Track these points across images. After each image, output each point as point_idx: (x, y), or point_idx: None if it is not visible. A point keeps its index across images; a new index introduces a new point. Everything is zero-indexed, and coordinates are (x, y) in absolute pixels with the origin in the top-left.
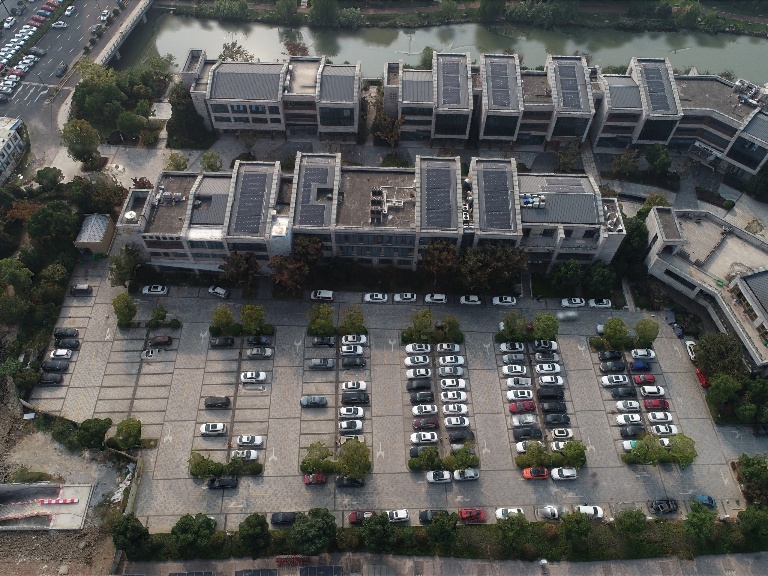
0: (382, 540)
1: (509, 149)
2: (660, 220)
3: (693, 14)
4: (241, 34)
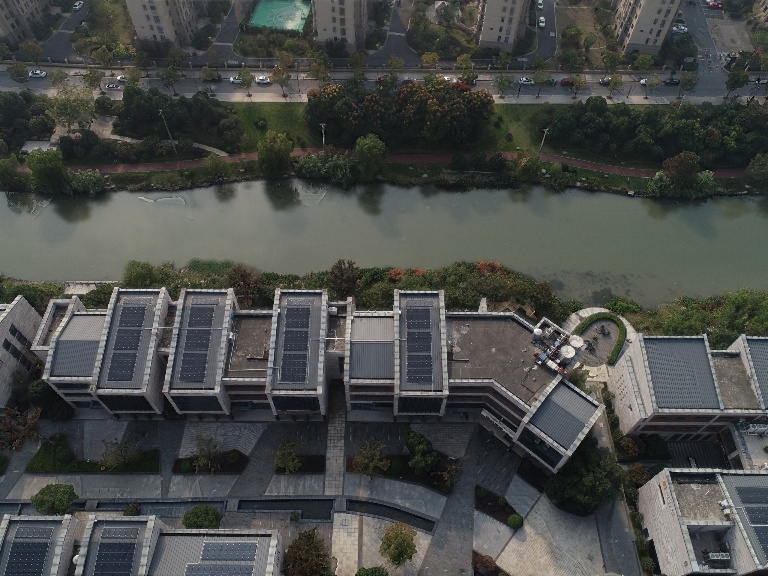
0: None
1: (228, 418)
2: None
3: (530, 170)
4: None
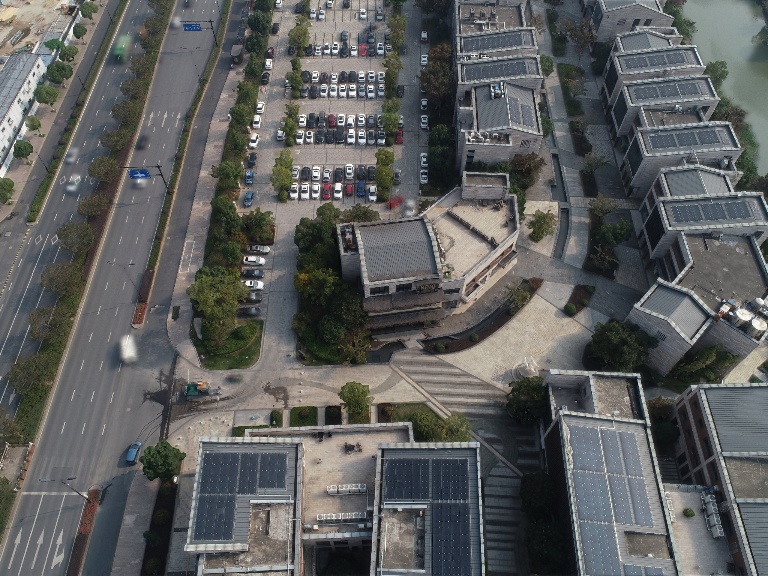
0: (249, 41)
1: None
2: (492, 178)
3: None
4: (737, 1)
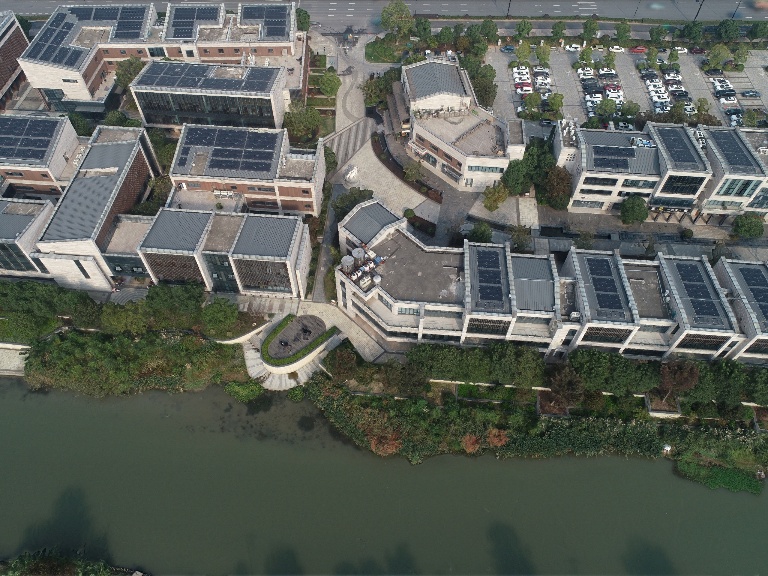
0: None
1: None
2: (521, 138)
3: None
4: None
